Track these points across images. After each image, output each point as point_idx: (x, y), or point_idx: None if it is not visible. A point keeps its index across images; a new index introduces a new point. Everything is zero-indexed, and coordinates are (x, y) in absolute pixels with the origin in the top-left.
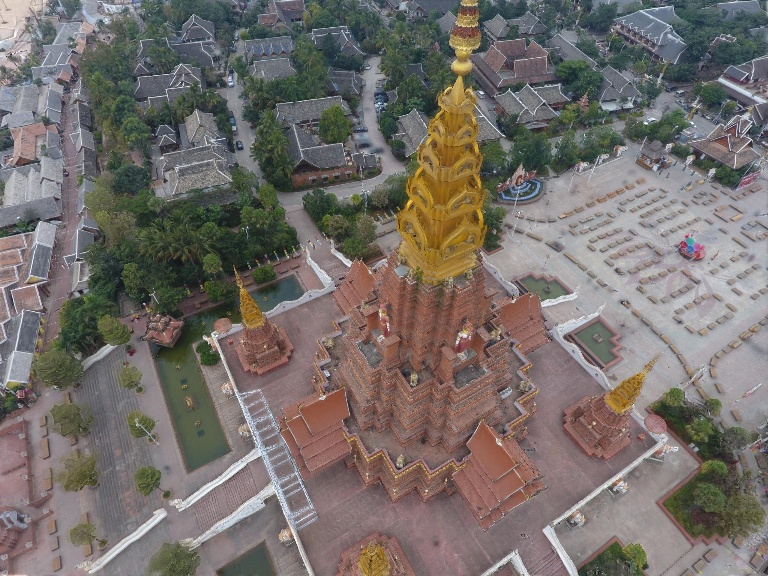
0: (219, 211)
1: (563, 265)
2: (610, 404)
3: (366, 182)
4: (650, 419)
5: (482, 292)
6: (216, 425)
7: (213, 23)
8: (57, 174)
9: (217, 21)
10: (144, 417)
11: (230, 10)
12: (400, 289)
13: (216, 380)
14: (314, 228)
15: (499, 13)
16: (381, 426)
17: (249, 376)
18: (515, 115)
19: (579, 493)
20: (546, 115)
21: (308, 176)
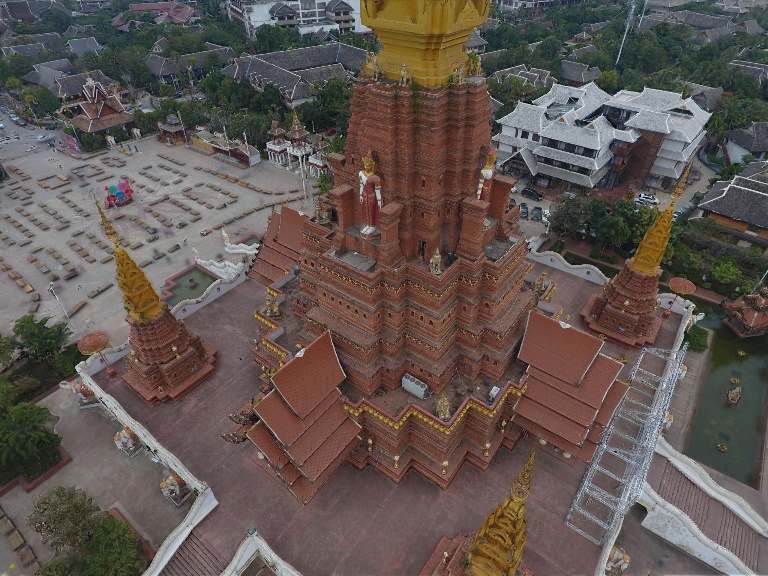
0: None
1: None
2: None
3: None
4: None
5: None
6: None
7: None
8: None
9: None
10: None
11: None
12: None
13: None
14: None
15: None
16: None
17: None
18: None
19: None
20: None
21: None
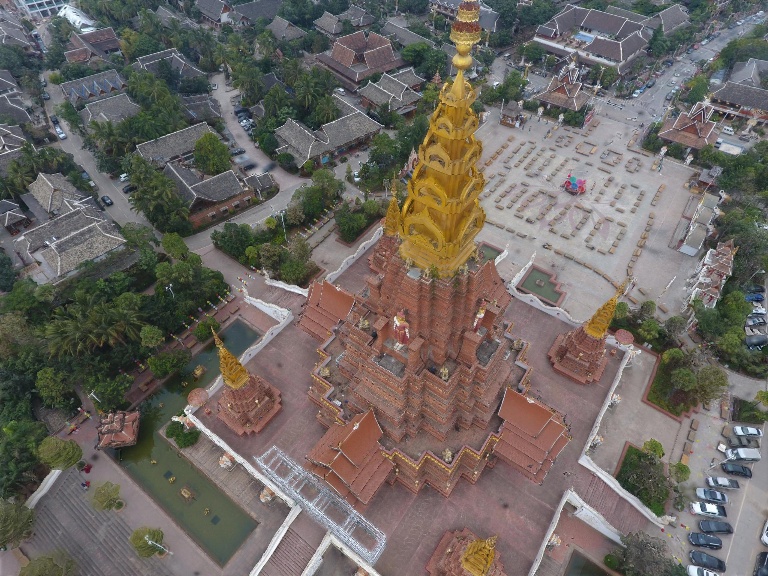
0: (124, 278)
1: (484, 229)
2: (591, 333)
3: (268, 203)
4: (619, 334)
5: None
6: (228, 504)
7: (8, 71)
8: None
9: (12, 68)
10: (150, 531)
11: (23, 53)
12: (418, 291)
13: (205, 458)
14: (236, 265)
15: (326, 10)
16: (415, 431)
17: (246, 439)
18: (385, 104)
19: (590, 418)
20: (412, 98)
21: (206, 213)
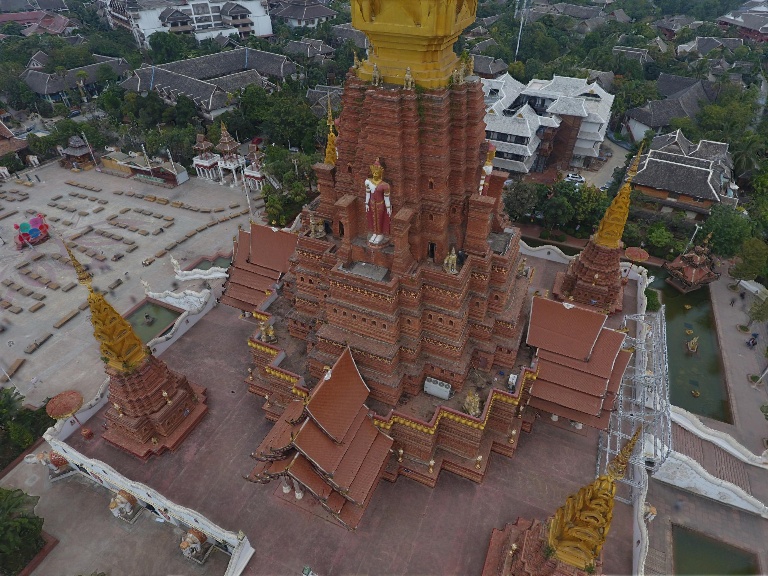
0: None
1: (85, 323)
2: None
3: None
4: None
5: None
6: None
7: None
8: None
9: None
10: None
11: None
12: None
13: None
14: None
15: None
16: None
17: None
18: None
19: None
20: None
21: None
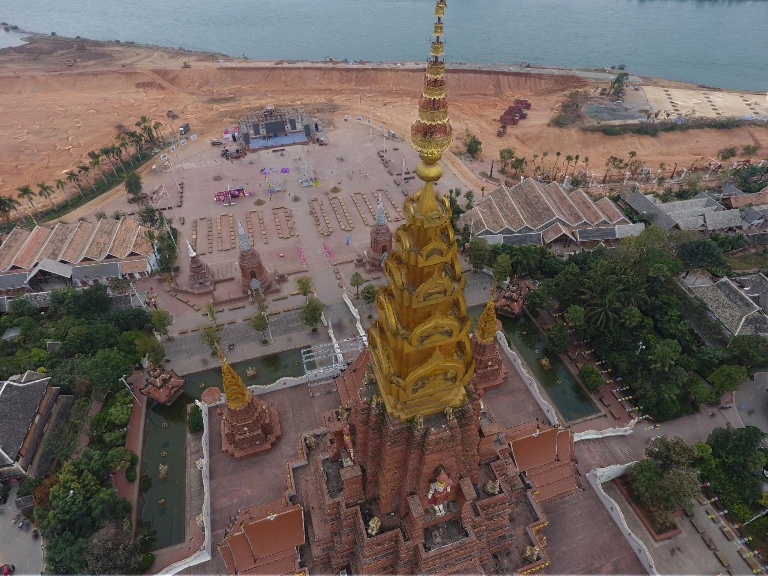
0: (679, 329)
1: None
2: None
3: None
4: None
5: (386, 457)
6: None
7: None
8: (719, 223)
9: None
10: None
11: None
12: None
13: None
14: None
15: None
16: None
17: None
18: None
19: None
20: None
21: None
